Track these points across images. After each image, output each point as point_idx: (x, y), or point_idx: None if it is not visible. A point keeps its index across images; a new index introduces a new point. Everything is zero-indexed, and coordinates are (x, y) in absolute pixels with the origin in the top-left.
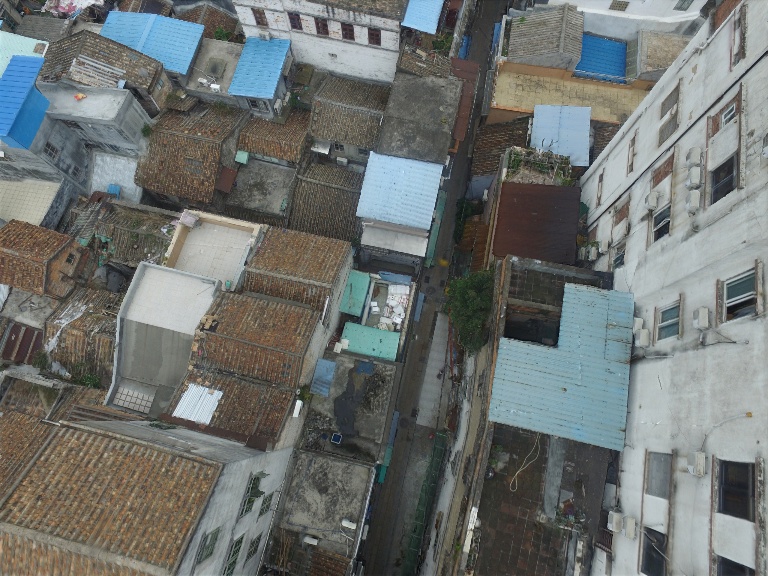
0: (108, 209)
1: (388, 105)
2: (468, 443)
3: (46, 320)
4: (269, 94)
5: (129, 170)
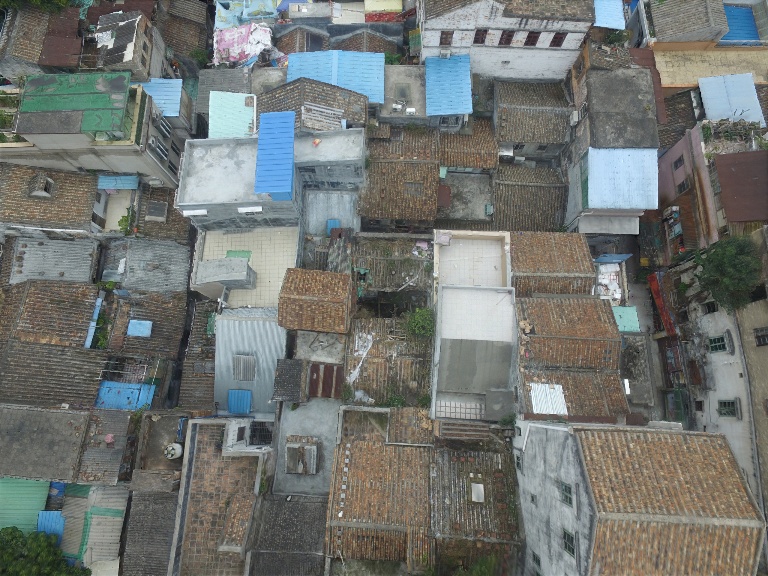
0: (353, 243)
1: (592, 102)
2: (760, 388)
3: (346, 354)
4: (468, 109)
5: (343, 203)
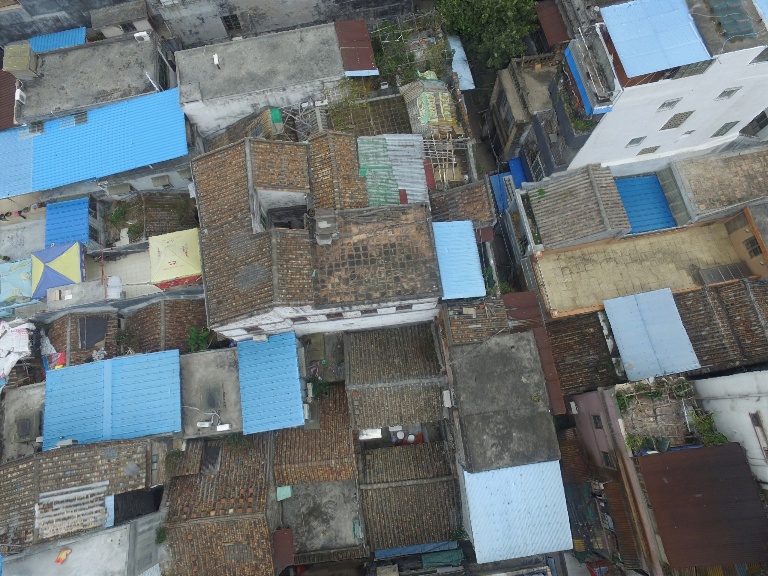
0: None
1: (459, 399)
2: None
3: None
4: (298, 420)
5: (149, 572)
